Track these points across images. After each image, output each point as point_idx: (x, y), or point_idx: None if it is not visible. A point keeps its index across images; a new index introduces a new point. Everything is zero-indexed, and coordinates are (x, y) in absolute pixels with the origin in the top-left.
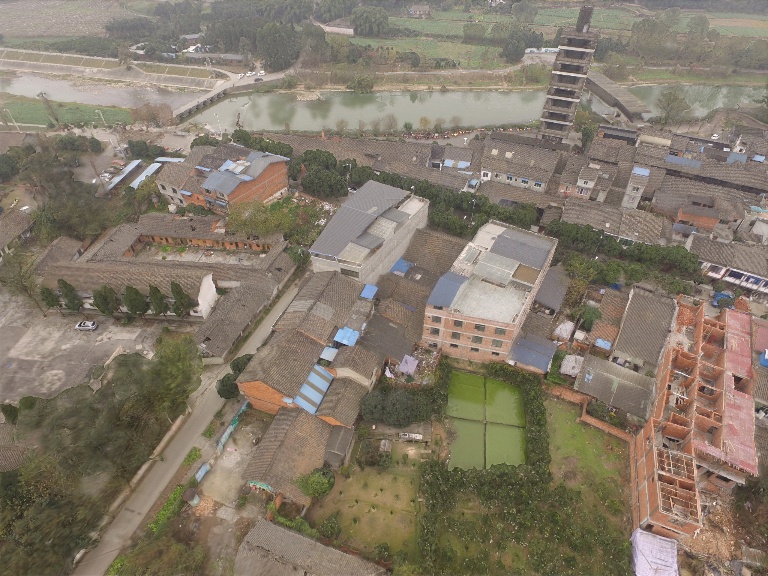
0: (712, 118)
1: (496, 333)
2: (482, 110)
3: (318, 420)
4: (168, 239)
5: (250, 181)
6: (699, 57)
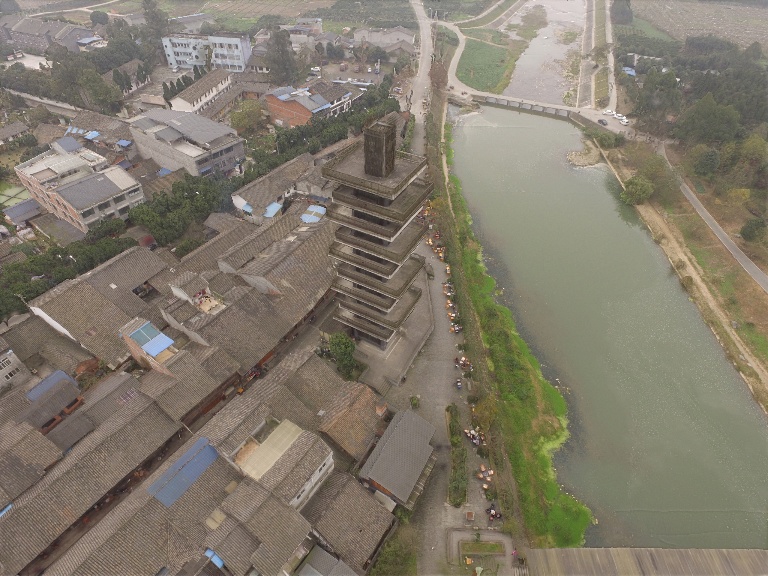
0: None
1: None
2: (598, 319)
3: None
4: None
5: None
6: None
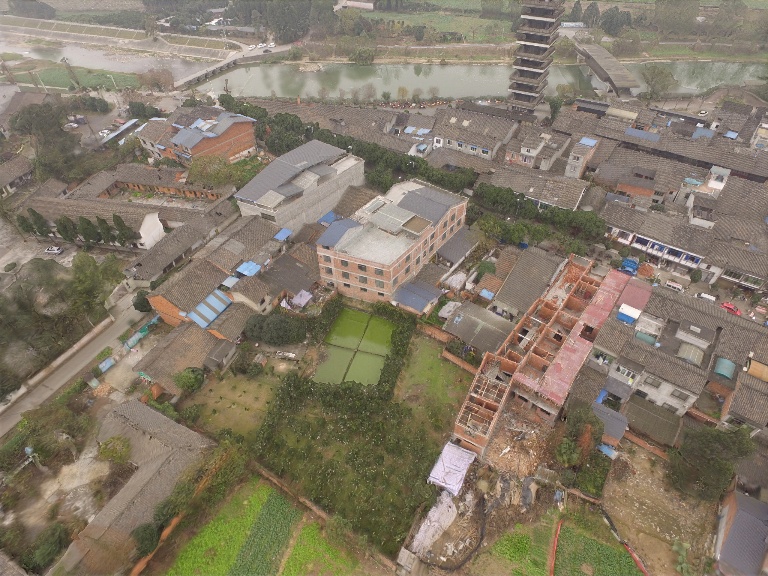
0: (710, 95)
1: (376, 274)
2: (474, 83)
3: (207, 333)
4: (139, 186)
5: (214, 138)
6: (730, 33)
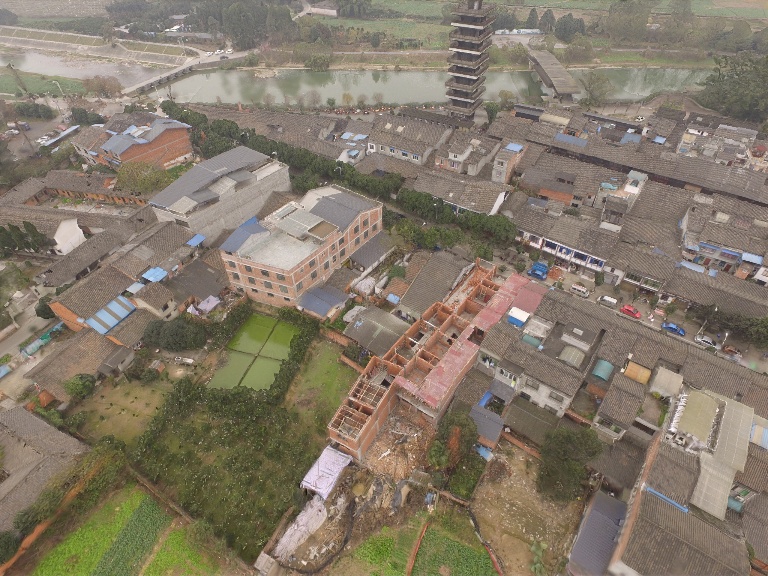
0: (651, 101)
1: (279, 279)
2: (425, 89)
3: (105, 339)
4: (69, 192)
5: (145, 144)
6: None
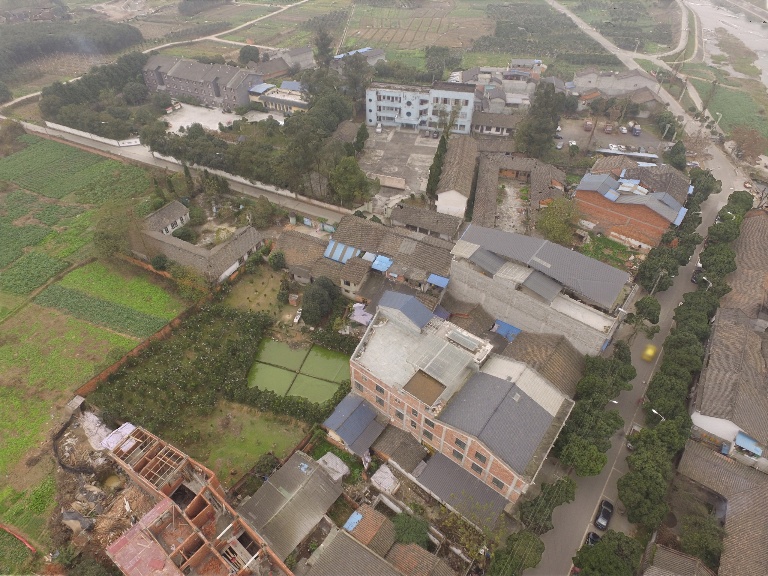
0: None
1: None
2: None
3: None
4: None
5: (610, 200)
6: None
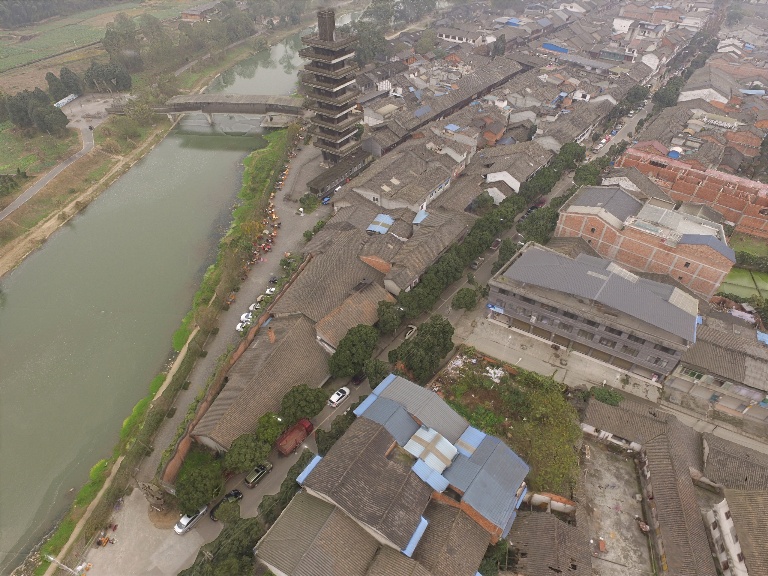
0: None
1: None
2: (180, 191)
3: None
4: None
5: None
6: None
